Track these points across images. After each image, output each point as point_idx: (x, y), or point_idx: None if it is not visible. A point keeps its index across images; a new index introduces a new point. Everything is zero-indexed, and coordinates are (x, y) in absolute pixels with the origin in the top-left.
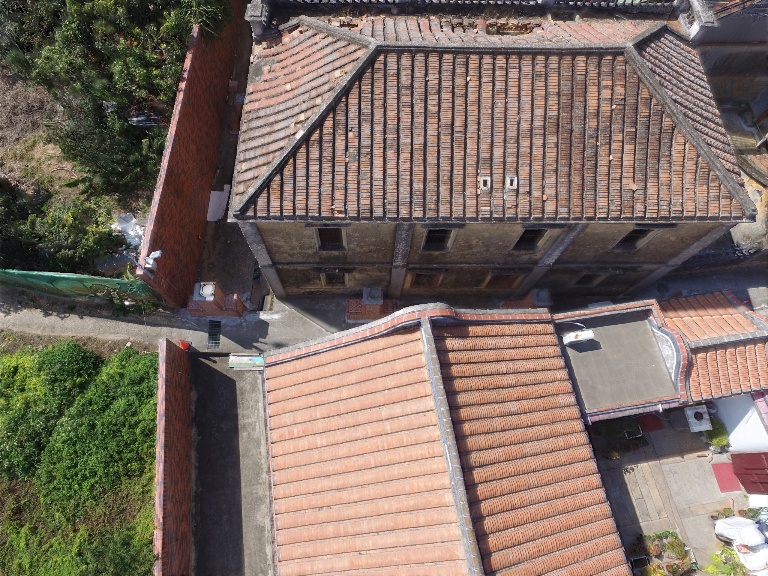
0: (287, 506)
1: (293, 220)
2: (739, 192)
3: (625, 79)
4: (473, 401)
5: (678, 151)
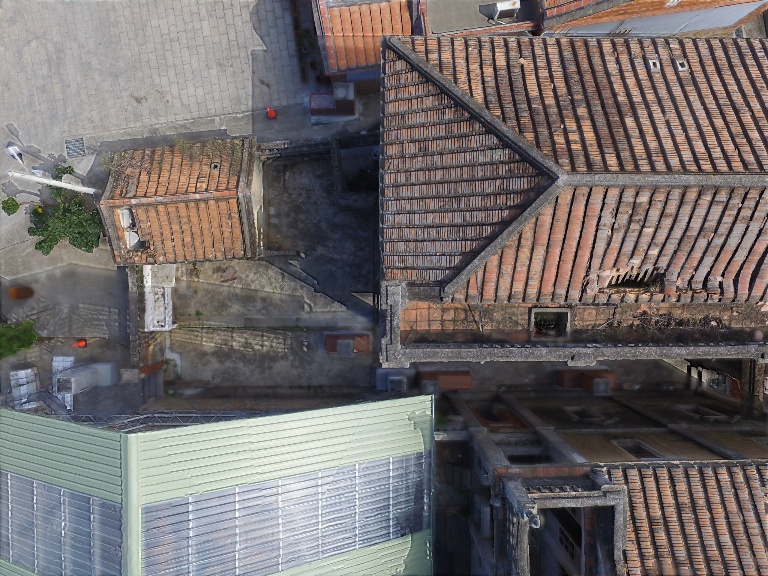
0: None
1: None
2: (411, 51)
3: (555, 151)
4: None
5: (478, 90)
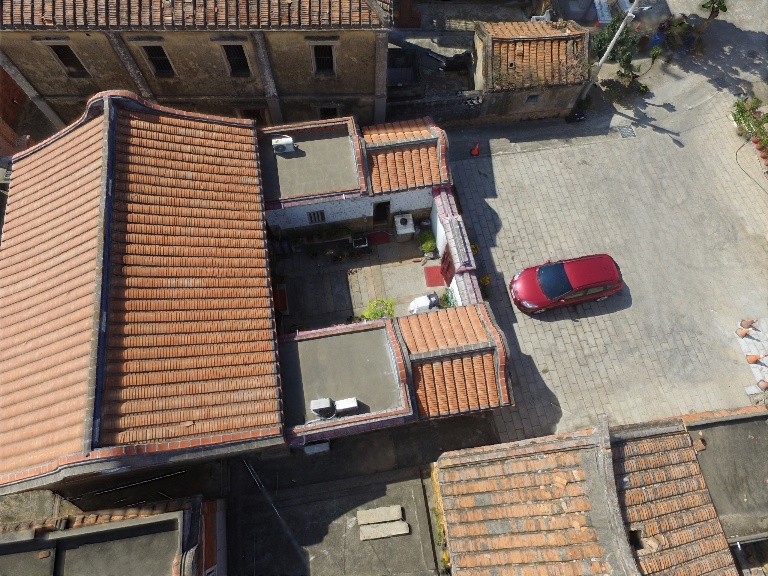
0: (6, 252)
1: (13, 29)
2: (372, 3)
3: None
4: (146, 162)
5: None
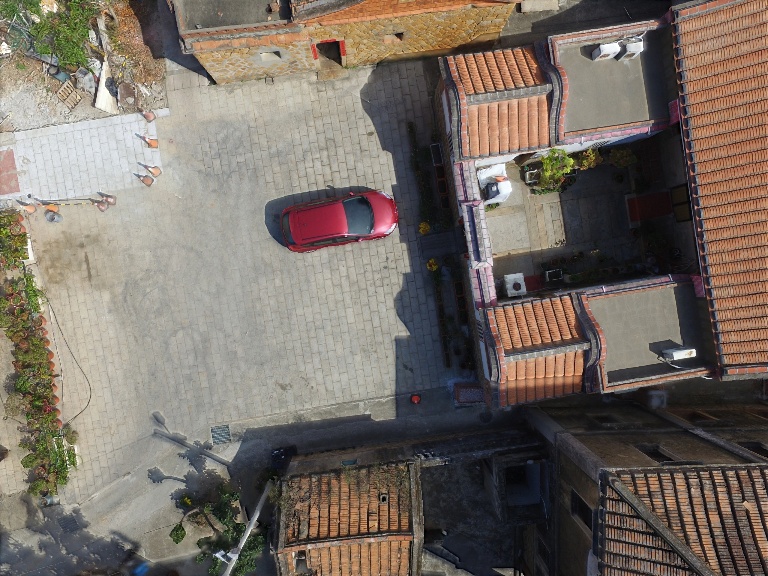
0: None
1: None
2: (639, 502)
3: None
4: None
5: (712, 551)
